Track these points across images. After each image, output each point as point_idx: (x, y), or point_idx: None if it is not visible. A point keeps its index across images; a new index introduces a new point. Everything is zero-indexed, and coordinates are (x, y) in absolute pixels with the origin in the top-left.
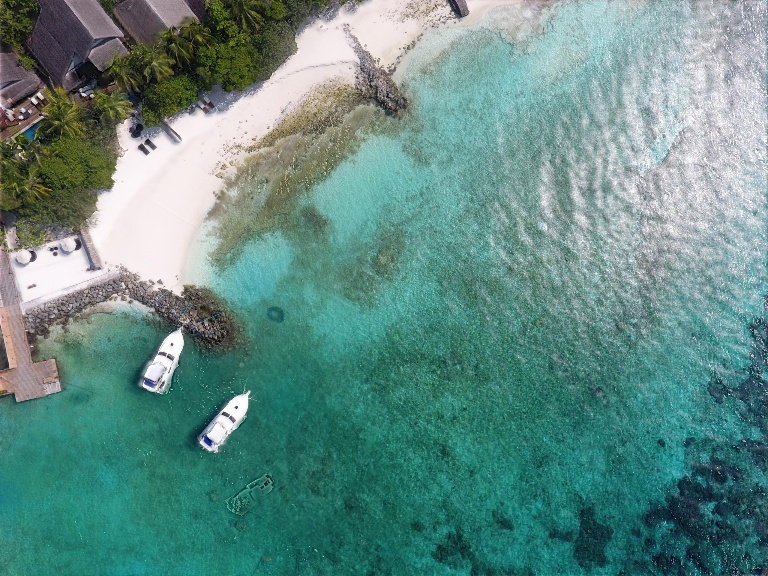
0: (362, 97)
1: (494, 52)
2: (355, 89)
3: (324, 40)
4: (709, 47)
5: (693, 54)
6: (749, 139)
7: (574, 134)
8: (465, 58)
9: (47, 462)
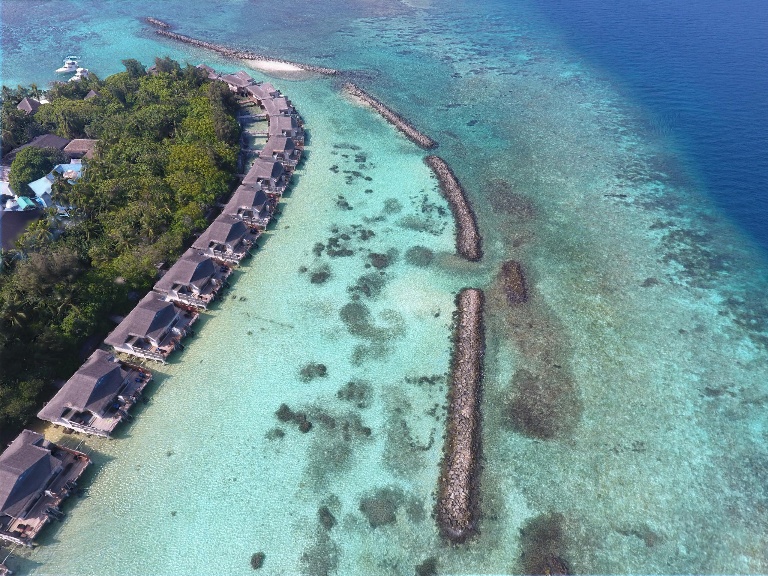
0: None
1: None
2: None
3: None
4: None
5: None
6: None
7: None
8: None
9: None
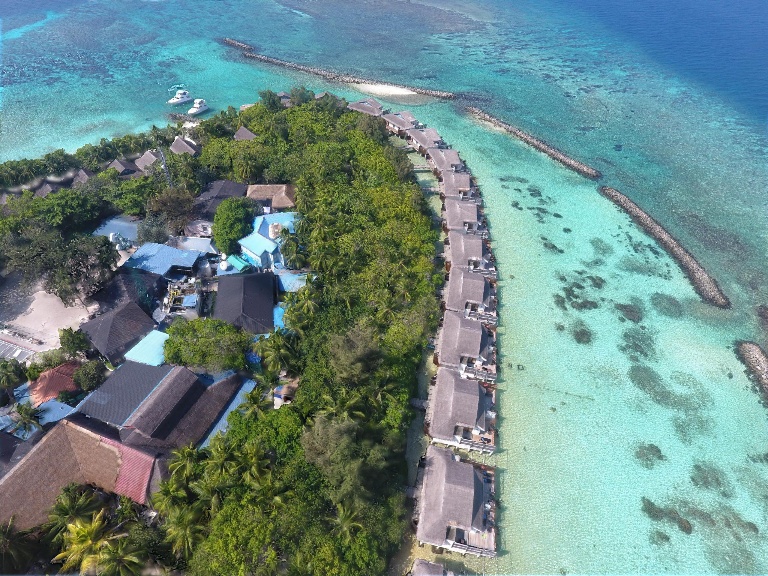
0: None
1: None
2: None
3: None
4: None
5: None
6: None
7: None
8: None
9: (251, 100)
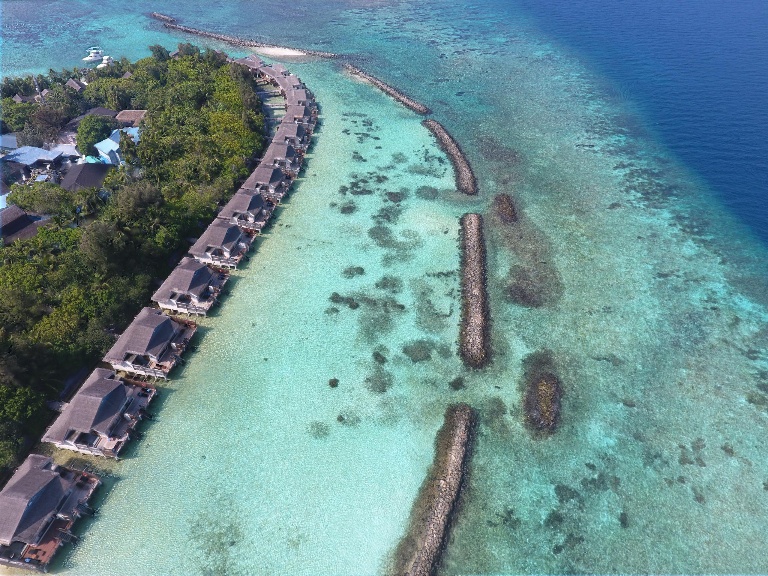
0: None
1: None
2: None
3: None
4: None
5: None
6: None
7: None
8: None
9: None
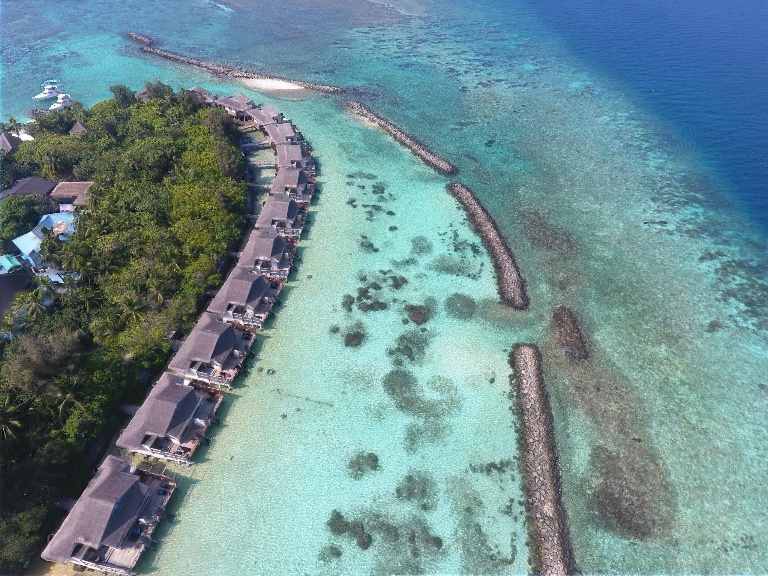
0: None
1: None
2: None
3: None
4: None
5: None
6: None
7: None
8: None
9: None
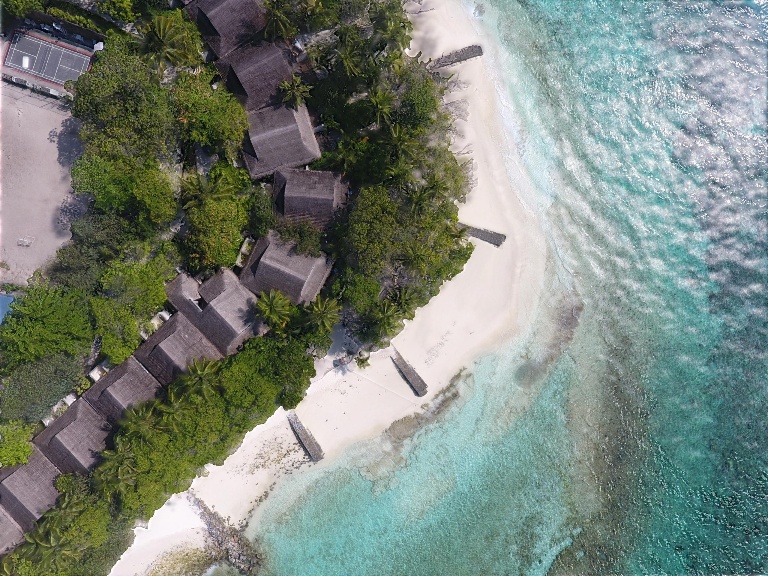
0: (213, 559)
1: (354, 490)
2: (205, 552)
3: (166, 513)
4: (586, 461)
5: (569, 470)
6: (632, 554)
7: (443, 569)
8: (323, 501)
9: None
